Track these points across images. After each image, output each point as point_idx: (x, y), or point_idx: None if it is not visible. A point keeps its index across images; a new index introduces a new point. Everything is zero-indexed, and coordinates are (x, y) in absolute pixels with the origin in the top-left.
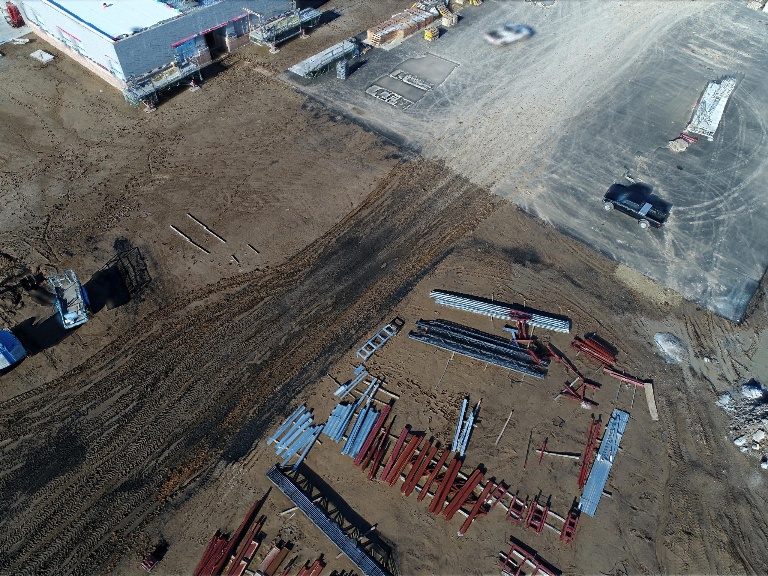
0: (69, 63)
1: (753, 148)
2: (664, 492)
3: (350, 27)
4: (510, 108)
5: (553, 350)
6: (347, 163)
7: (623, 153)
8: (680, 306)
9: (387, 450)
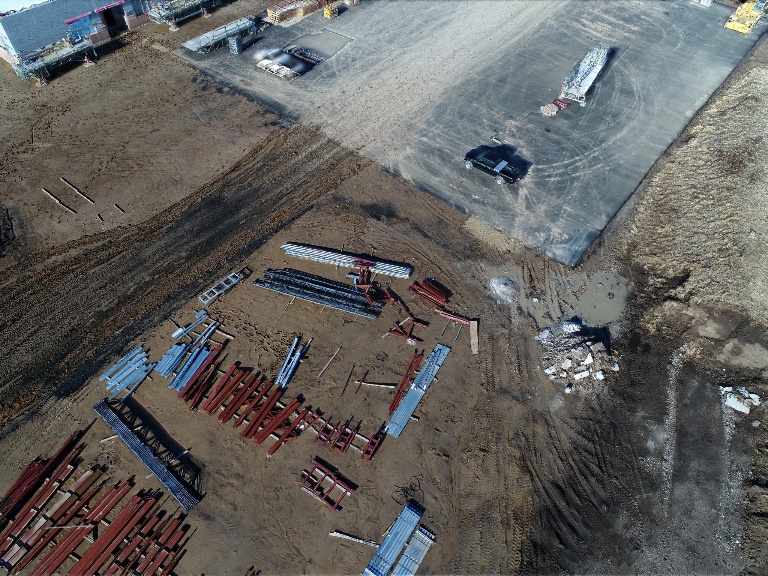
0: None
1: (622, 112)
2: (470, 416)
3: (253, 6)
4: (394, 78)
5: (390, 294)
6: (226, 130)
7: (495, 118)
8: (521, 253)
9: (213, 384)
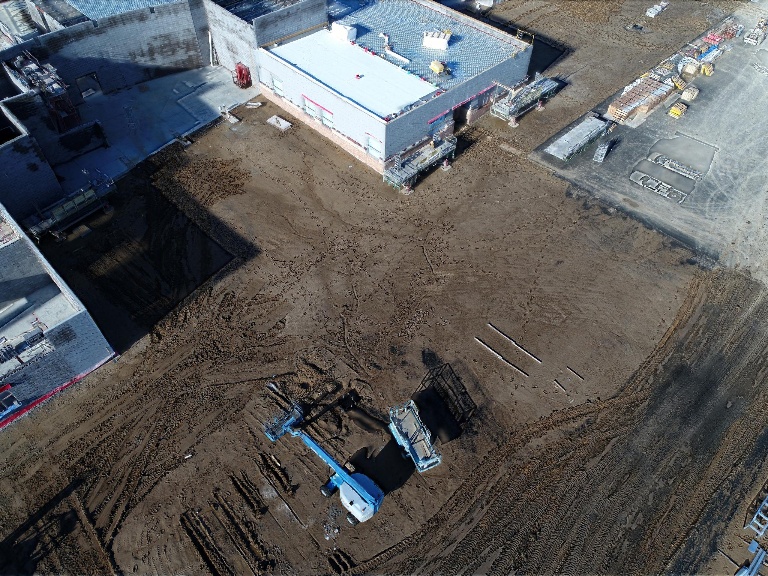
0: (308, 132)
1: None
2: None
3: (583, 98)
4: None
5: None
6: (640, 268)
7: None
8: None
9: None
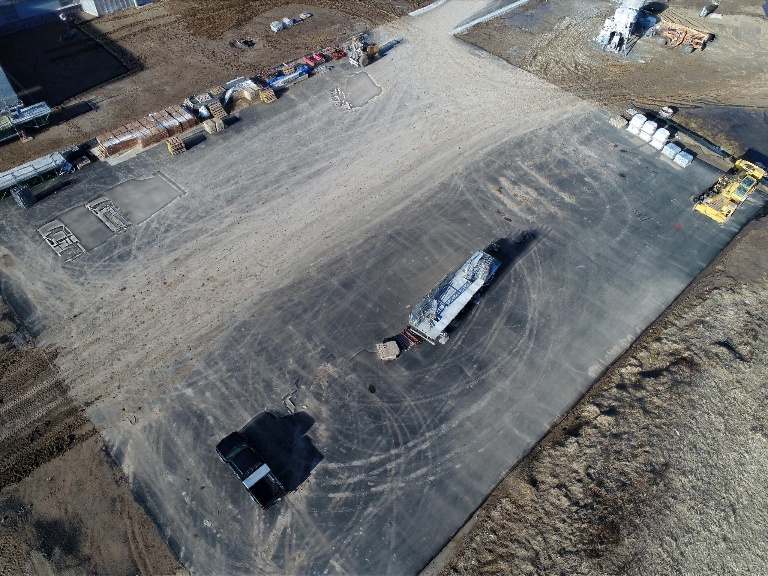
0: None
1: (495, 360)
2: None
3: (92, 127)
4: (203, 269)
5: None
6: None
7: (308, 357)
8: None
9: None
